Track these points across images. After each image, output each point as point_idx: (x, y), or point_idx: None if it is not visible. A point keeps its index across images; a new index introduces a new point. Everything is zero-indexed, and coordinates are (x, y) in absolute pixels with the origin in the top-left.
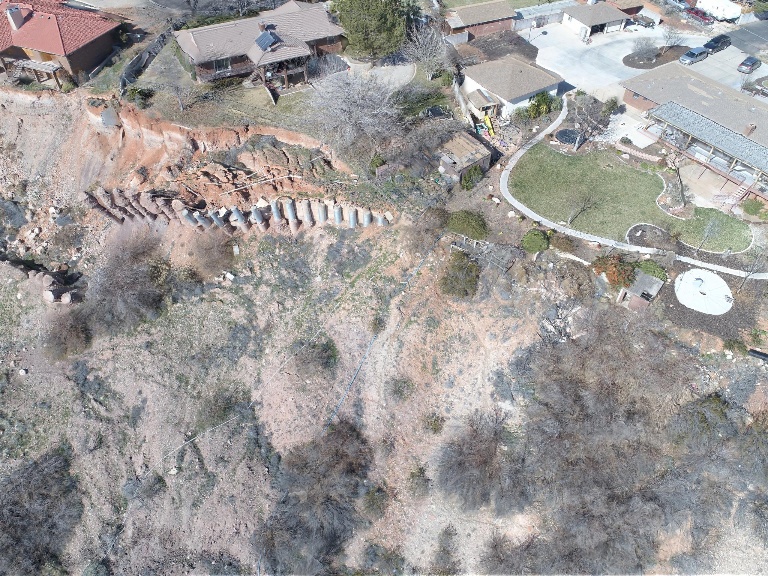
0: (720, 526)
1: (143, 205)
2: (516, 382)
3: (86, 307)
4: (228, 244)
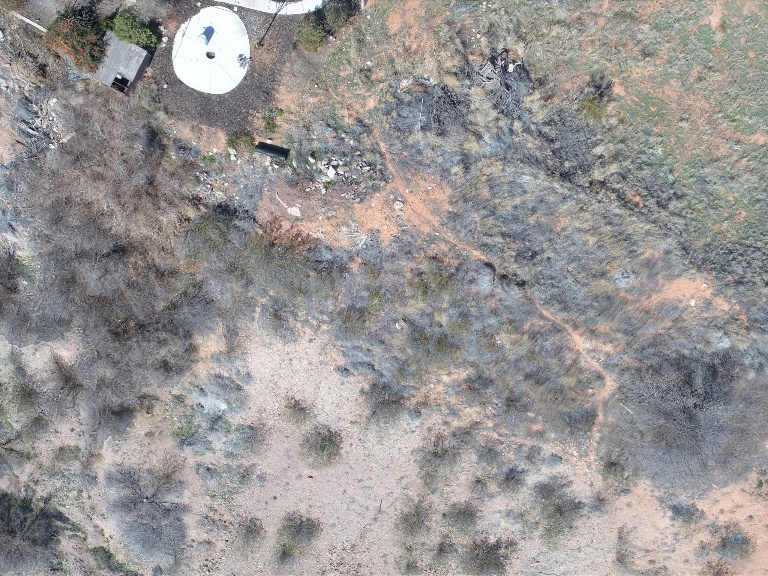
0: (247, 329)
1: None
2: (11, 209)
3: None
4: None
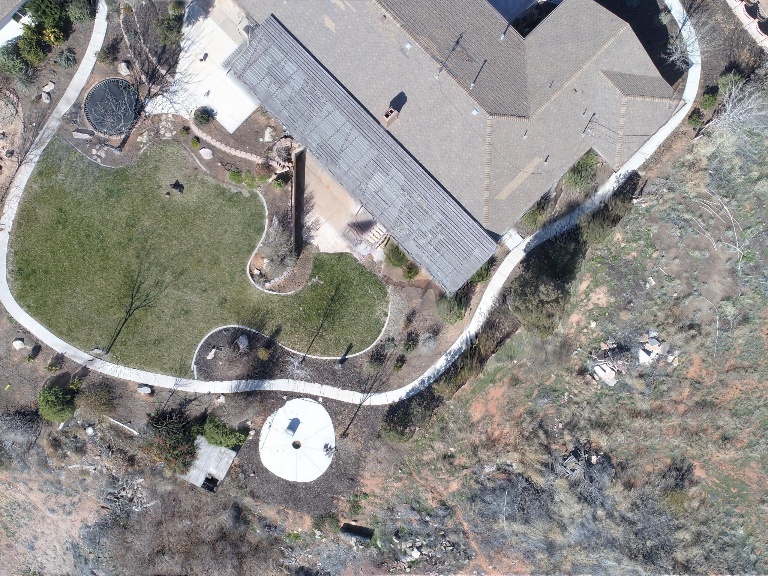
0: None
1: None
2: (93, 558)
3: None
4: None
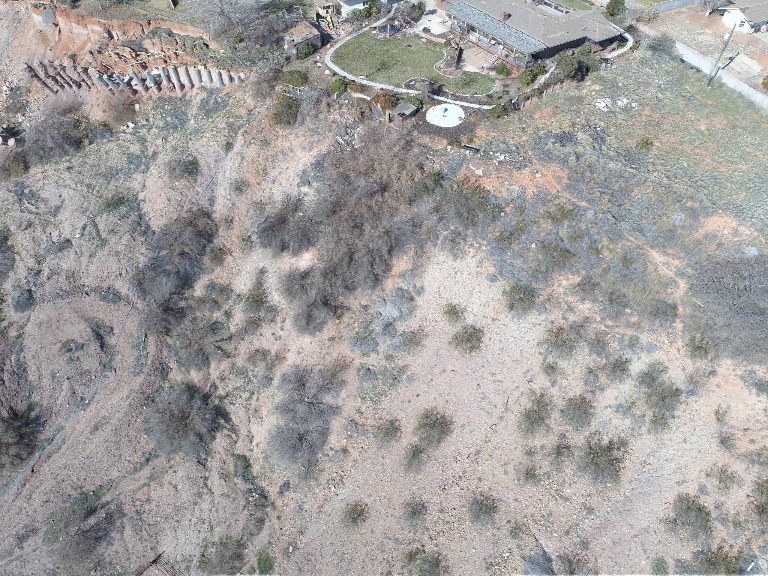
0: (430, 252)
1: (68, 73)
2: (313, 174)
3: (25, 146)
4: (132, 104)
